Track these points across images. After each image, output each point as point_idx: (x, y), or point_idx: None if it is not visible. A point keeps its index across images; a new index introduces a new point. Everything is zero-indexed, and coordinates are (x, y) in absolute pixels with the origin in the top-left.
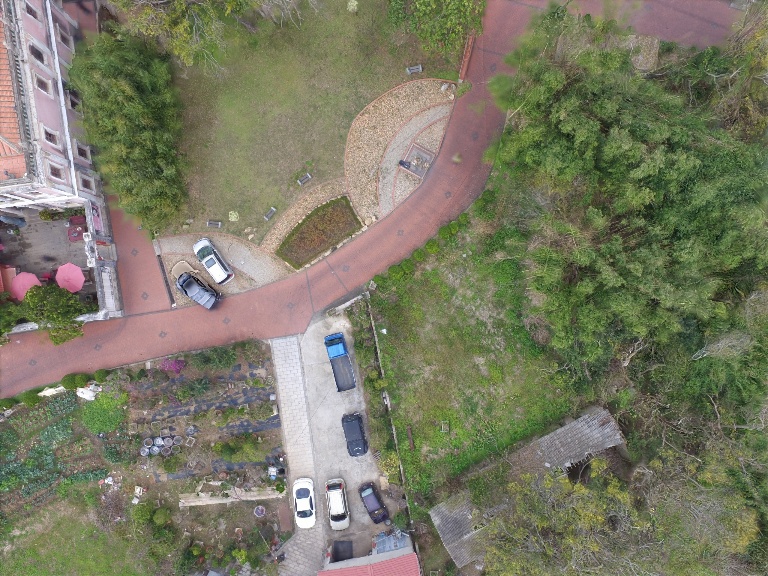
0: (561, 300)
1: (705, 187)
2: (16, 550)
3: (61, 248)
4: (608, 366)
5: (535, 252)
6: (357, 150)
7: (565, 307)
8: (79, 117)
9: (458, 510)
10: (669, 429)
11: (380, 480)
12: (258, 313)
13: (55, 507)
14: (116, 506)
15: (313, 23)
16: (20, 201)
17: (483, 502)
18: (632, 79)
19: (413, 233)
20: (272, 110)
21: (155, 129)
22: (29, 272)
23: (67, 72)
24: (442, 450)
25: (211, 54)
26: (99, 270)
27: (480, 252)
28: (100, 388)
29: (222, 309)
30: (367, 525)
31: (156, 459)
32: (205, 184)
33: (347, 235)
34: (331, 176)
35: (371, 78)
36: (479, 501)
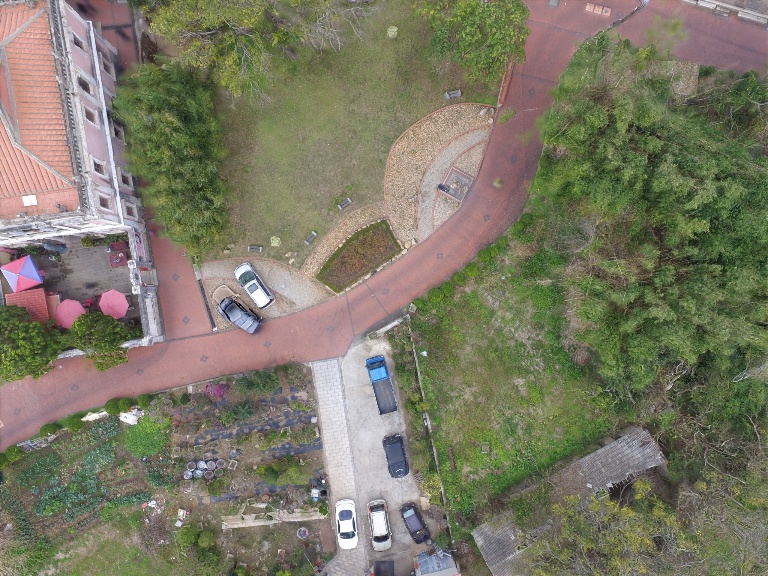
0: (612, 329)
1: (750, 214)
2: (60, 574)
3: (102, 273)
4: (648, 388)
5: (574, 274)
6: (396, 174)
7: (616, 336)
8: (121, 144)
9: (501, 531)
10: (711, 450)
11: (421, 500)
12: (299, 336)
13: (99, 531)
14: (160, 529)
15: (352, 48)
16: (66, 230)
17: (526, 523)
18: (672, 104)
19: (452, 256)
20: (312, 135)
21: (201, 158)
22: (71, 298)
23: (110, 100)
24: (482, 470)
25: (257, 83)
26: (143, 297)
27: (519, 274)
28: (143, 412)
29: (263, 333)
30: (408, 545)
31: (200, 483)
32: (246, 209)
33: (387, 258)
34: (371, 200)
35: (410, 102)
36: (522, 522)
